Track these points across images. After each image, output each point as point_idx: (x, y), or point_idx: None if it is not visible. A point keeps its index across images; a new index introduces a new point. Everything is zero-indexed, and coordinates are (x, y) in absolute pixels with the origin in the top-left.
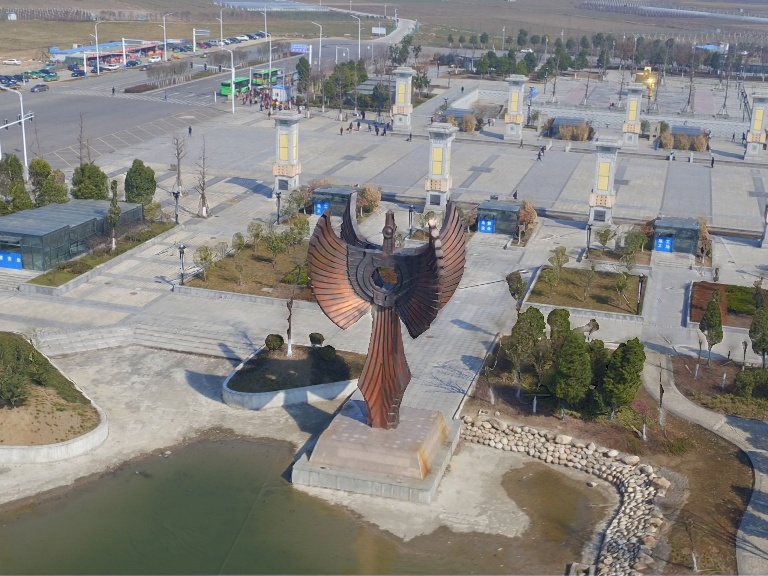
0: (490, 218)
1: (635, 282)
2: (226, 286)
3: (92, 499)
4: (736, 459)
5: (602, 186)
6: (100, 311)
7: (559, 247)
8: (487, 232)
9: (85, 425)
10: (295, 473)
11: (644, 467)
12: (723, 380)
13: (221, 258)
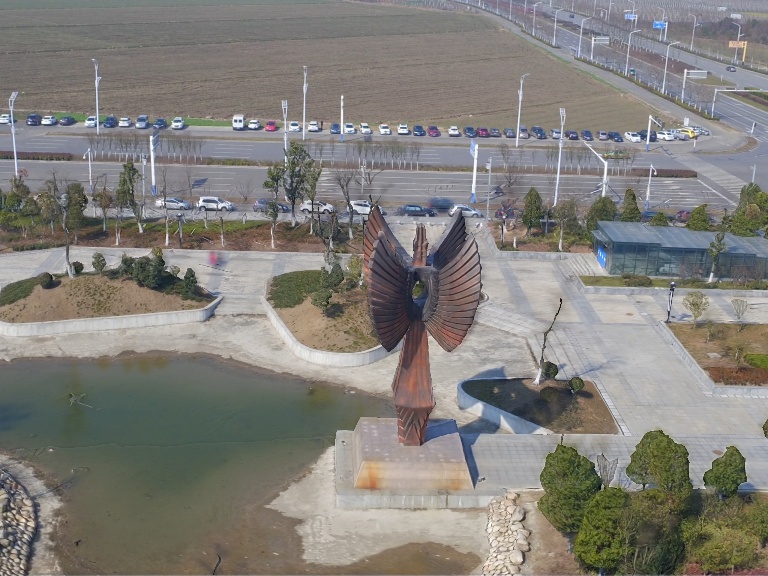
0: None
1: None
2: (693, 338)
3: (262, 383)
4: None
5: None
6: (571, 312)
7: None
8: None
9: (345, 349)
10: None
11: None
12: None
13: (736, 316)
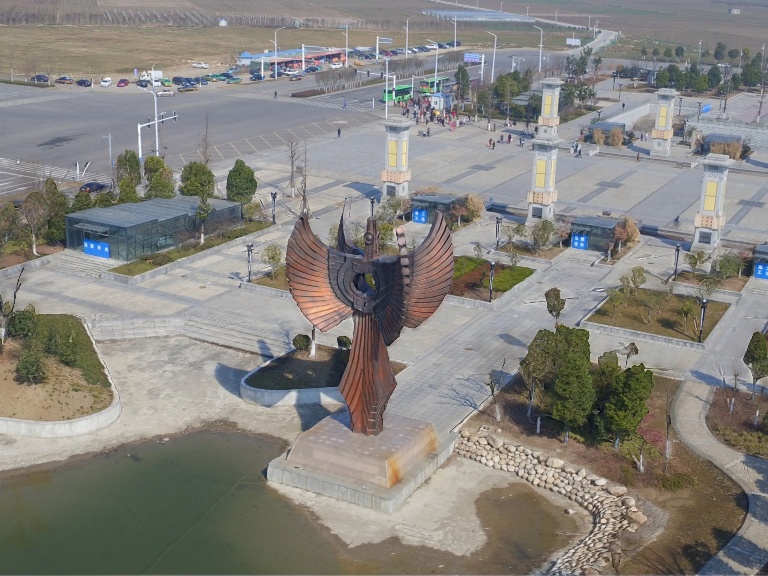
0: (591, 234)
1: (715, 308)
2: None
3: (77, 476)
4: (733, 501)
5: (708, 206)
6: (163, 302)
7: (636, 267)
8: (580, 248)
9: (95, 406)
10: (270, 470)
11: (626, 499)
12: (756, 417)
13: None
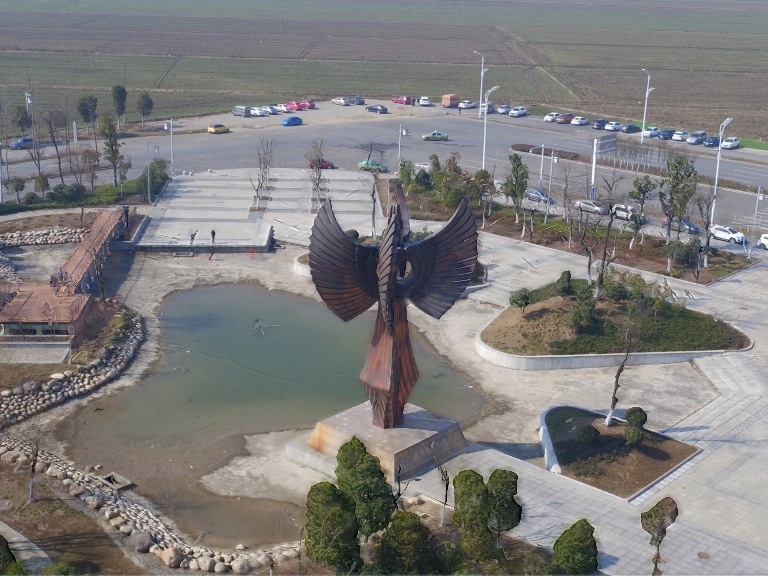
0: None
1: None
2: None
3: None
4: None
5: None
6: None
7: None
8: None
9: (509, 349)
10: None
11: None
12: None
13: None
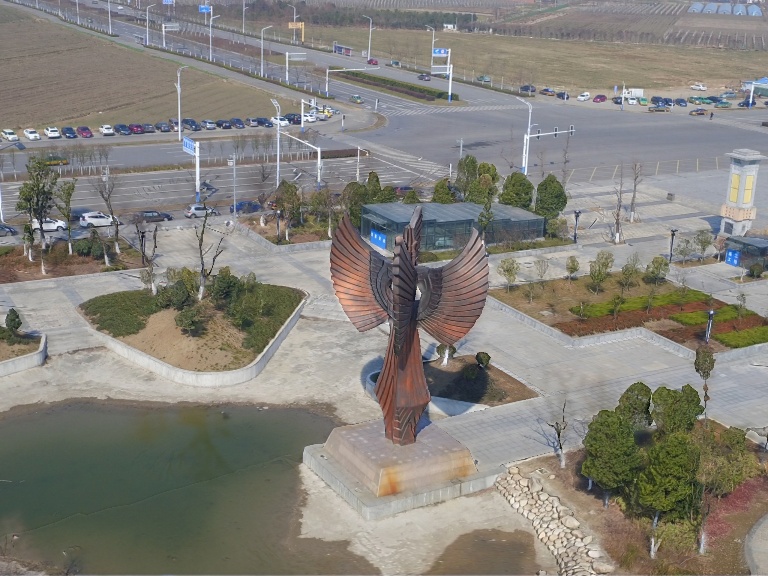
0: None
1: None
2: (516, 301)
3: (168, 417)
4: None
5: None
6: None
7: None
8: None
9: (229, 366)
10: (305, 453)
11: None
12: None
13: (539, 276)
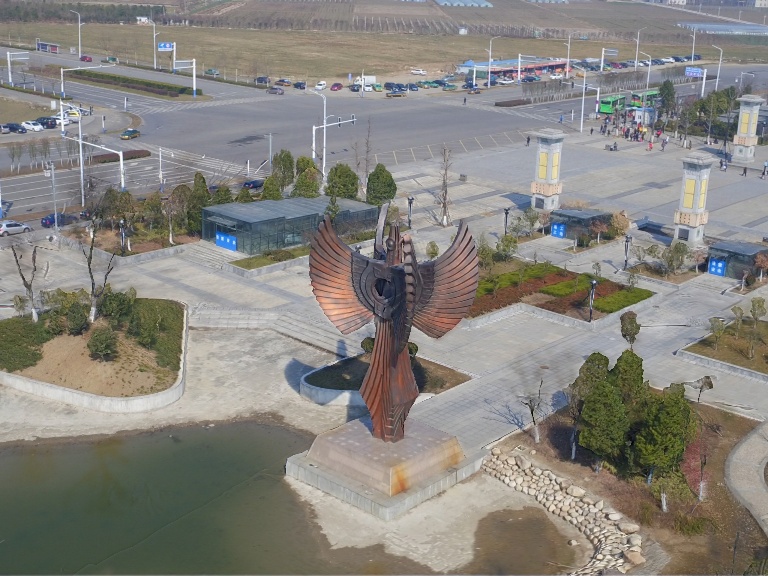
0: (737, 260)
1: None
2: None
3: (116, 450)
4: (752, 554)
5: None
6: (268, 296)
7: (756, 298)
8: (716, 274)
9: (156, 387)
10: (288, 465)
11: (631, 537)
12: None
13: None
